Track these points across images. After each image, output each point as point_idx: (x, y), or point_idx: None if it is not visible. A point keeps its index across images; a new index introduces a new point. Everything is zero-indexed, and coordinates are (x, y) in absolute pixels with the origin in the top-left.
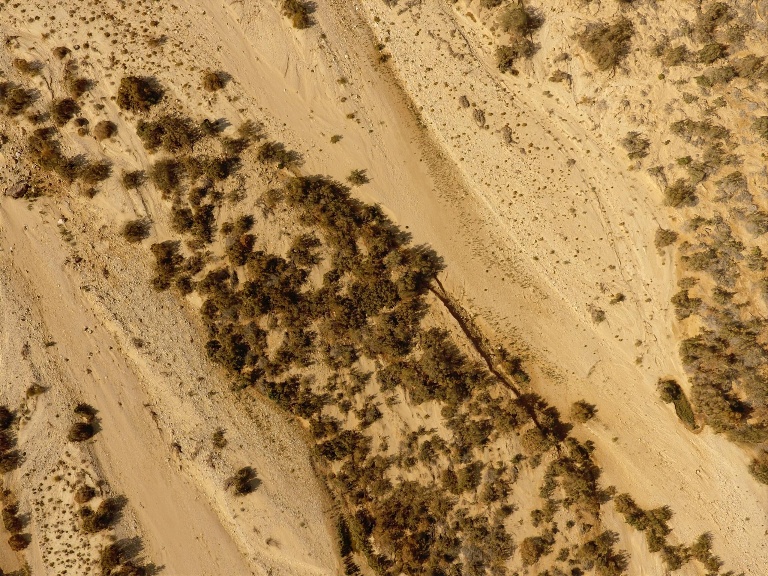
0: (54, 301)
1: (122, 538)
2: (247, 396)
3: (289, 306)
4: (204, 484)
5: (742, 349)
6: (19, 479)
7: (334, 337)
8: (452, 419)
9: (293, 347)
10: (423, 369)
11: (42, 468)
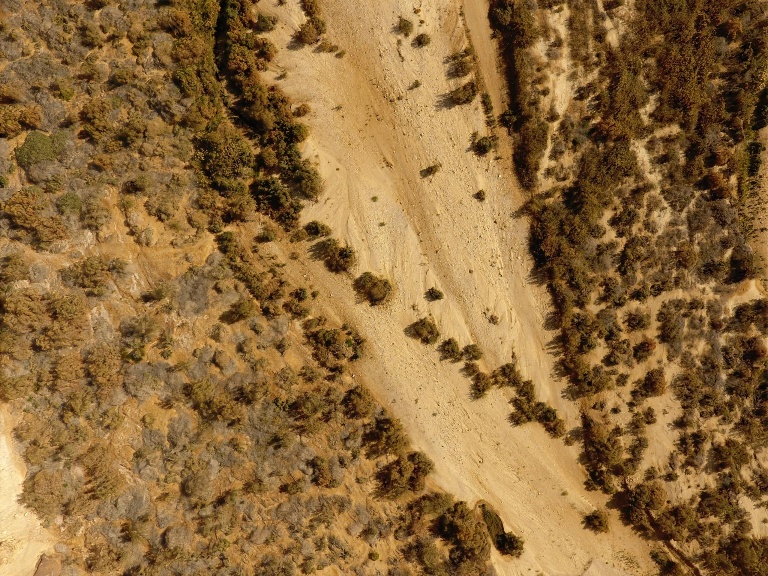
0: None
1: None
2: None
3: None
4: None
5: None
6: None
7: None
8: (740, 520)
9: None
10: None
11: None
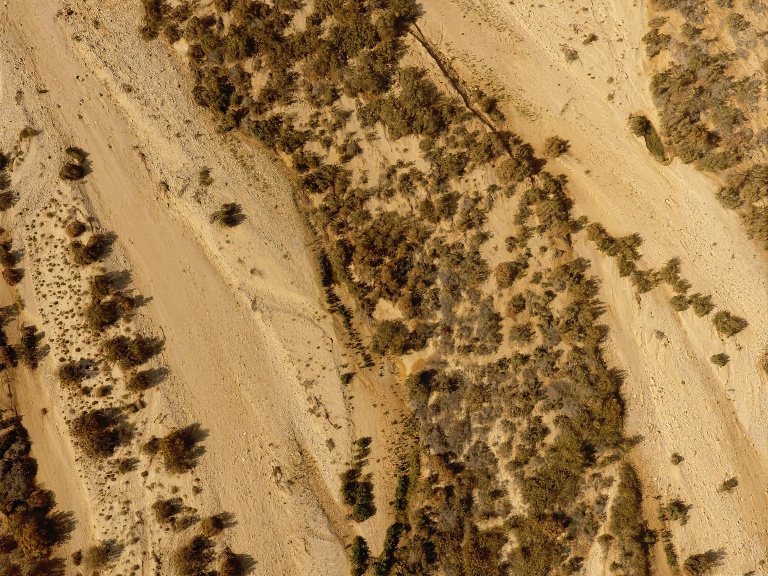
0: (47, 52)
1: (112, 271)
2: (232, 138)
3: (272, 43)
4: (191, 220)
5: (710, 81)
6: (13, 218)
7: (316, 77)
8: (430, 151)
9: (276, 85)
10: (402, 104)
11: (35, 207)
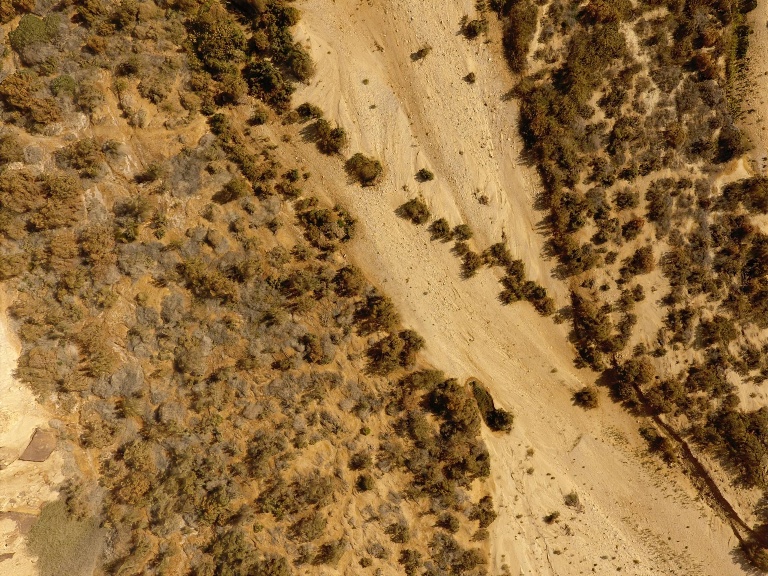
0: None
1: None
2: None
3: None
4: None
5: (430, 468)
6: None
7: None
8: (728, 394)
9: None
10: None
11: None
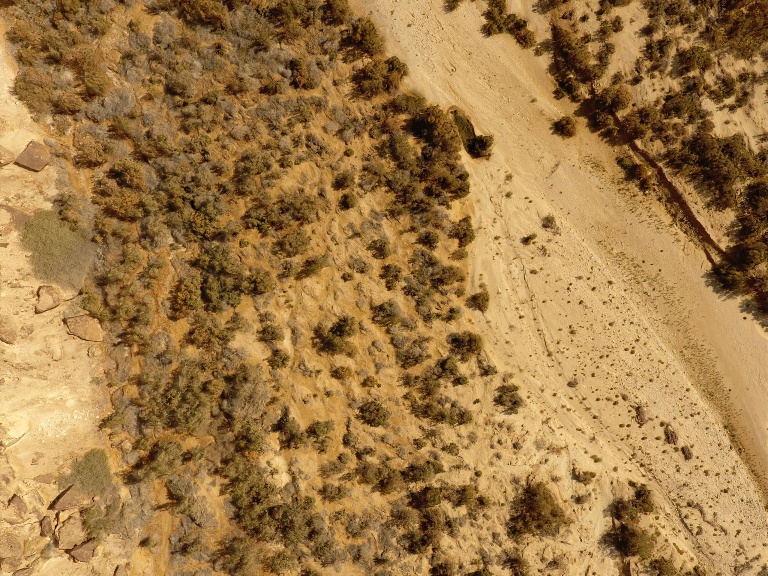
0: None
1: None
2: None
3: None
4: None
5: (411, 187)
6: None
7: None
8: (703, 120)
9: None
10: None
11: None
